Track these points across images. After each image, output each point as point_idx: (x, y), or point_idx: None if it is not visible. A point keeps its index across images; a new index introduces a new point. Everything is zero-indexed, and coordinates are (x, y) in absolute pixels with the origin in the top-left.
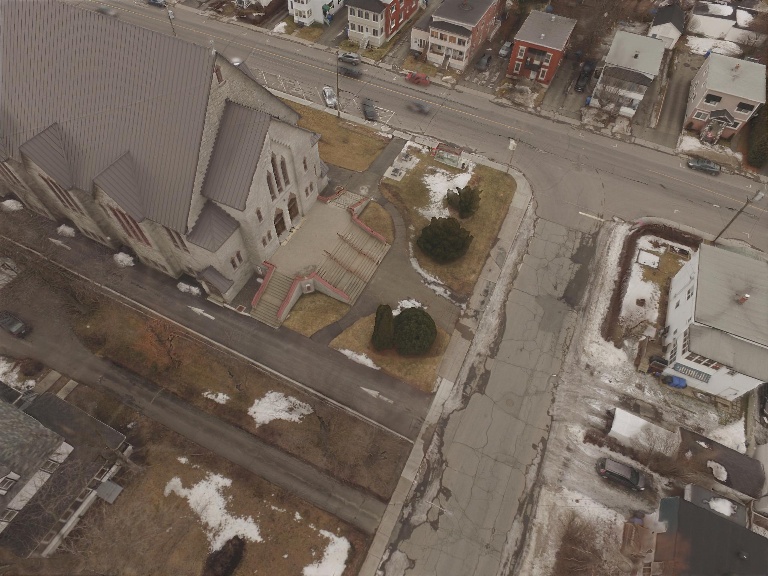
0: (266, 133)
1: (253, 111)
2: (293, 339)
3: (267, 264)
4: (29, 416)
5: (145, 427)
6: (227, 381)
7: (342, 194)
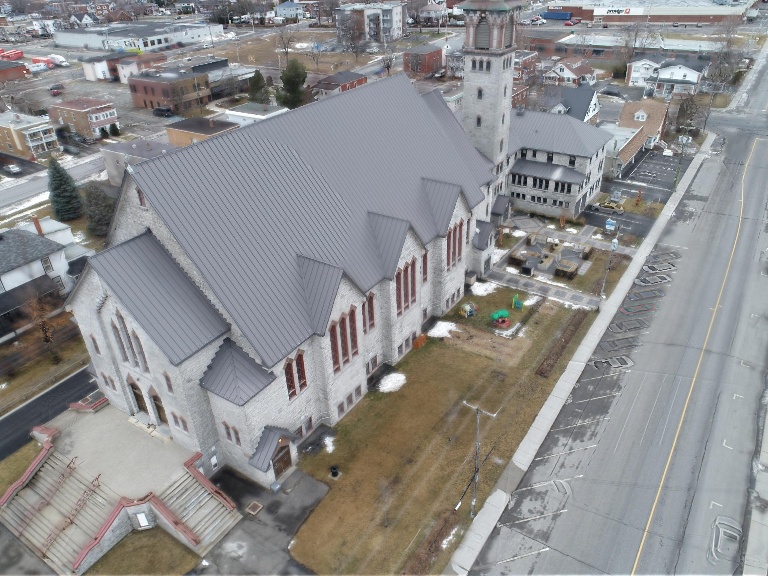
0: (84, 269)
1: (112, 247)
2: (4, 451)
3: (99, 400)
4: (15, 268)
5: (5, 351)
6: (2, 398)
7: (221, 503)
